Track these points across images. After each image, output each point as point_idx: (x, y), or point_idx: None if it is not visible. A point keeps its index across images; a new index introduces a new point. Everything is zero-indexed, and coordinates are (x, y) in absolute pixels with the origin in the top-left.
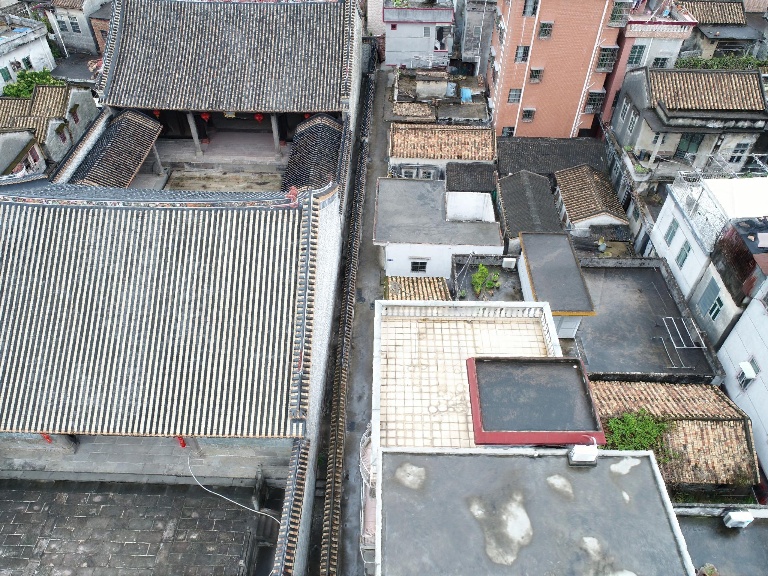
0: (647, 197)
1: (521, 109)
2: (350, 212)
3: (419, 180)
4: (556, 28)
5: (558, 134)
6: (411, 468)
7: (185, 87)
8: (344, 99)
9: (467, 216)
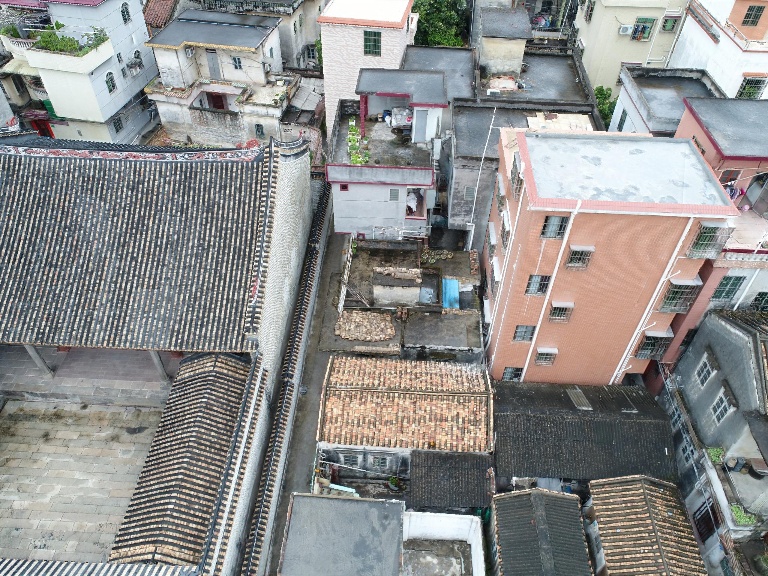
0: (747, 544)
1: (534, 349)
2: (247, 542)
3: (360, 500)
4: (597, 254)
5: (591, 377)
6: None
7: (5, 301)
8: (249, 335)
9: (443, 536)
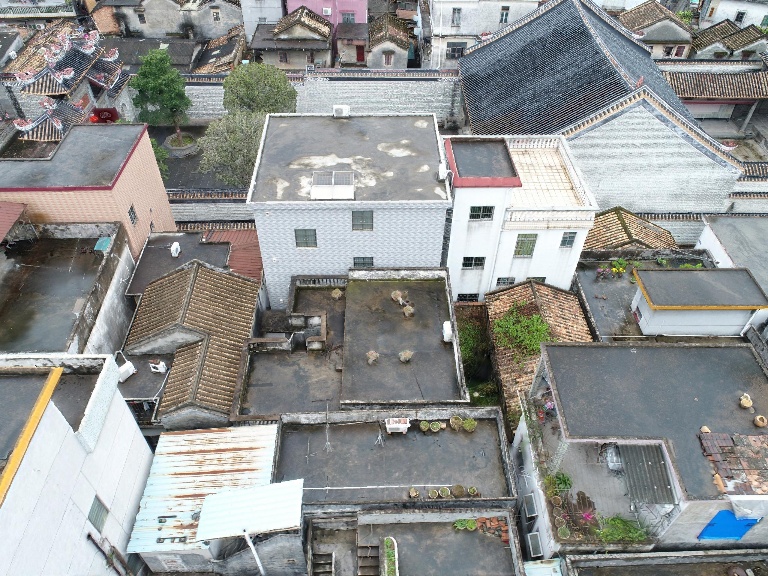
0: None
1: None
2: None
3: None
4: None
5: None
6: (426, 124)
7: None
8: None
9: None
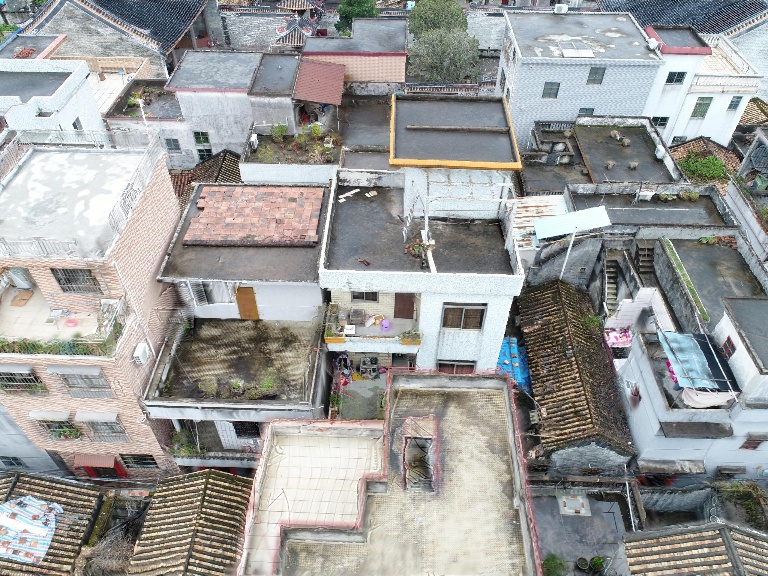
0: None
1: None
2: None
3: None
4: None
5: None
6: (625, 19)
7: None
8: None
9: None
